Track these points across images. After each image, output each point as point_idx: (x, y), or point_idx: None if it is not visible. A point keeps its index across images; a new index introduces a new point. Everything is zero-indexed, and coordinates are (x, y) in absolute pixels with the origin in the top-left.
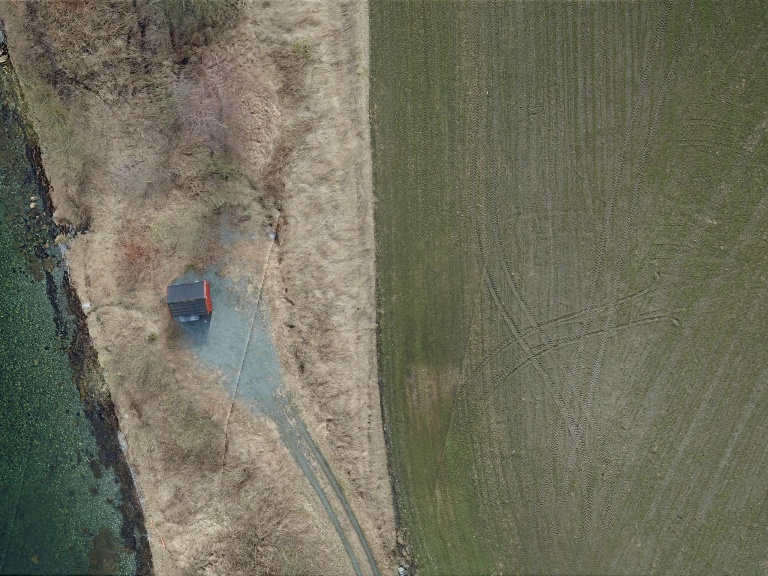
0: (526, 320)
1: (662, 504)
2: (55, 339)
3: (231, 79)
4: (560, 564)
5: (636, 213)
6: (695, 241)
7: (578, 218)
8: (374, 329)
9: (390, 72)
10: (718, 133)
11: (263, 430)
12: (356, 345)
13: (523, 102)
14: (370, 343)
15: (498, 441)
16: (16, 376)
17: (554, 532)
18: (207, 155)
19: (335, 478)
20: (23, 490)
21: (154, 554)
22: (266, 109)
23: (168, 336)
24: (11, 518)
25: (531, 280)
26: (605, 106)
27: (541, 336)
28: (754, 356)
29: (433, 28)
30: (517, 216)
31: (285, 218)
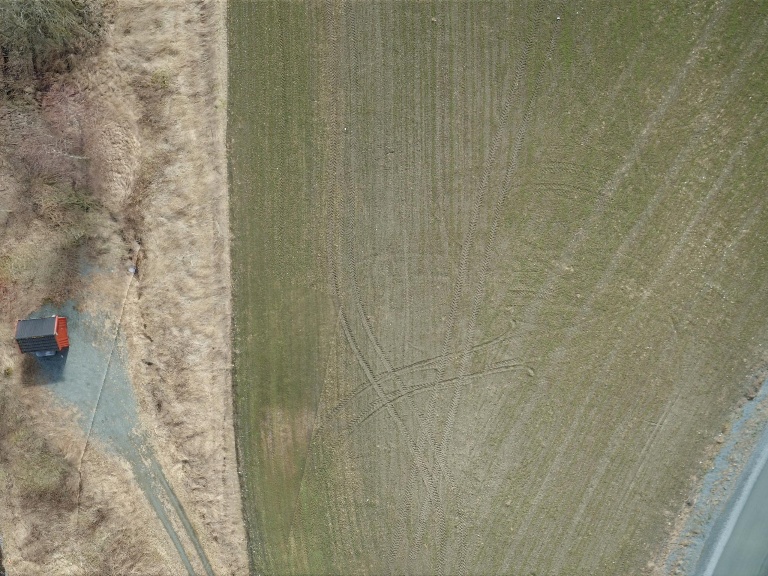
0: (381, 365)
1: (515, 559)
2: None
3: (93, 108)
4: None
5: (492, 258)
6: (551, 288)
7: (434, 261)
8: (229, 369)
9: (248, 105)
10: (577, 177)
11: (117, 470)
12: (211, 385)
13: (381, 140)
14: (225, 384)
15: (352, 488)
16: None
17: None
18: (69, 185)
19: (189, 521)
20: None
21: None
22: (126, 140)
23: (24, 371)
24: None
25: (387, 324)
26: (463, 146)
27: (396, 382)
28: (610, 409)
29: (292, 61)
30: (373, 257)
31: (145, 252)
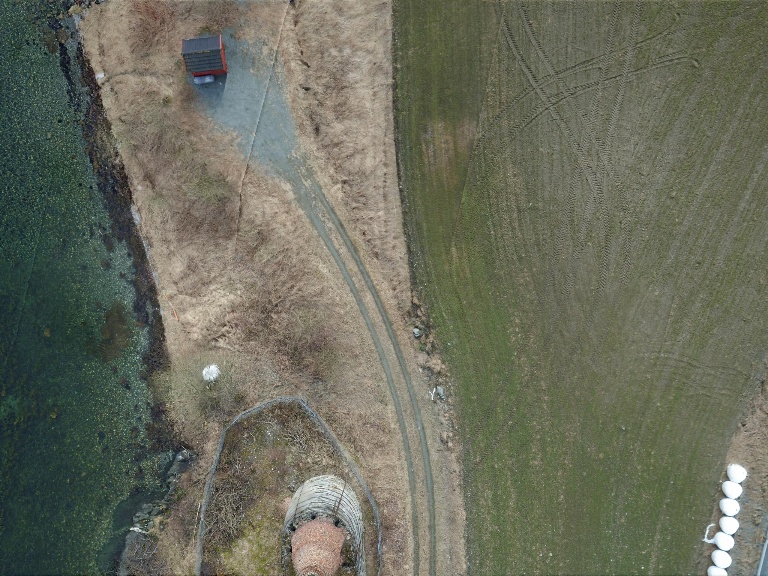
0: (544, 68)
1: (680, 250)
2: (68, 111)
3: None
4: (577, 316)
5: None
6: None
7: None
8: (390, 84)
9: None
10: None
11: (278, 191)
12: (372, 102)
13: None
14: (386, 99)
15: (515, 194)
16: (29, 149)
17: (571, 284)
18: None
19: (350, 239)
20: (35, 265)
21: (167, 327)
22: None
23: (183, 98)
24: (23, 293)
25: (549, 27)
26: None
27: (559, 84)
28: None
29: None
30: None
31: None
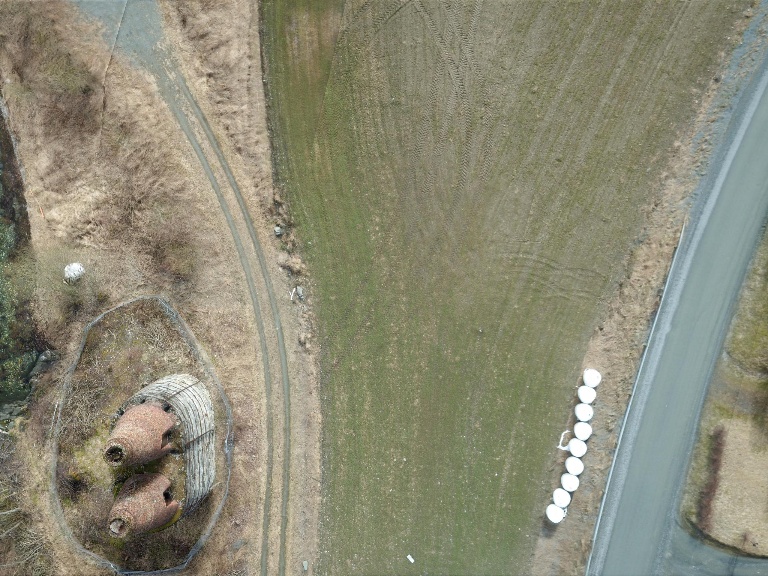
0: None
1: (541, 147)
2: None
3: None
4: (437, 215)
5: None
6: None
7: None
8: None
9: None
10: None
11: (141, 83)
12: None
13: None
14: None
15: (378, 89)
16: None
17: (432, 182)
18: None
19: (213, 133)
20: None
21: (32, 223)
22: None
23: None
24: None
25: None
26: None
27: None
28: None
29: None
30: None
31: None
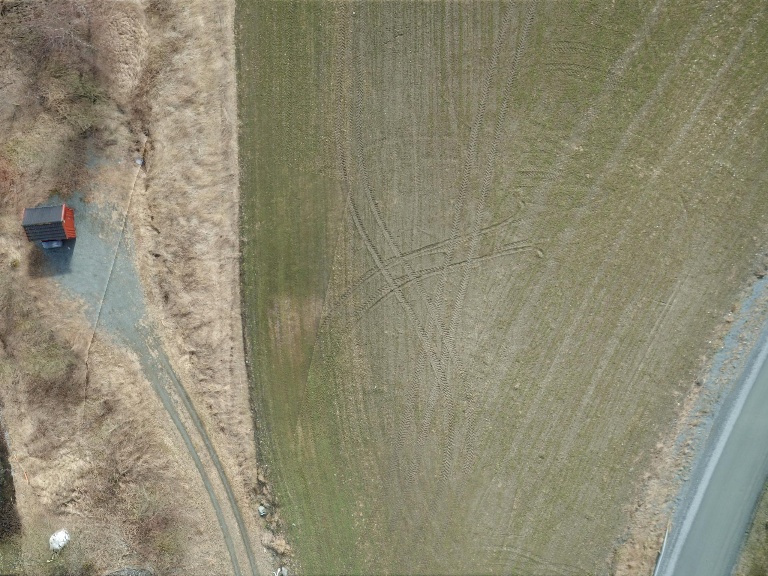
0: (389, 250)
1: (523, 443)
2: None
3: None
4: (420, 504)
5: (501, 139)
6: (561, 169)
7: (443, 144)
8: (237, 258)
9: None
10: (586, 56)
11: (124, 361)
12: (219, 274)
13: (389, 23)
14: (233, 272)
15: (360, 376)
16: None
17: (415, 471)
18: (76, 78)
19: (196, 412)
20: None
21: (17, 489)
22: (134, 30)
23: (30, 263)
24: None
25: (395, 208)
26: (472, 27)
27: (404, 267)
28: (619, 289)
29: None
30: (382, 141)
31: (152, 143)
